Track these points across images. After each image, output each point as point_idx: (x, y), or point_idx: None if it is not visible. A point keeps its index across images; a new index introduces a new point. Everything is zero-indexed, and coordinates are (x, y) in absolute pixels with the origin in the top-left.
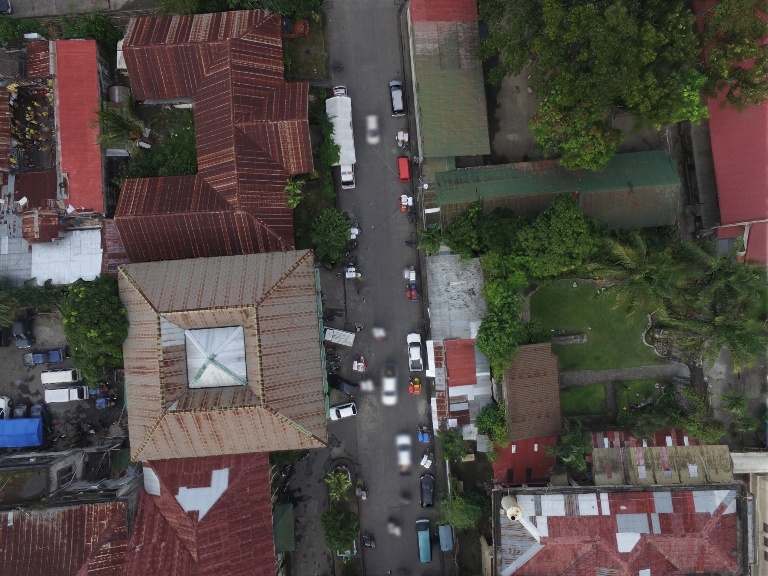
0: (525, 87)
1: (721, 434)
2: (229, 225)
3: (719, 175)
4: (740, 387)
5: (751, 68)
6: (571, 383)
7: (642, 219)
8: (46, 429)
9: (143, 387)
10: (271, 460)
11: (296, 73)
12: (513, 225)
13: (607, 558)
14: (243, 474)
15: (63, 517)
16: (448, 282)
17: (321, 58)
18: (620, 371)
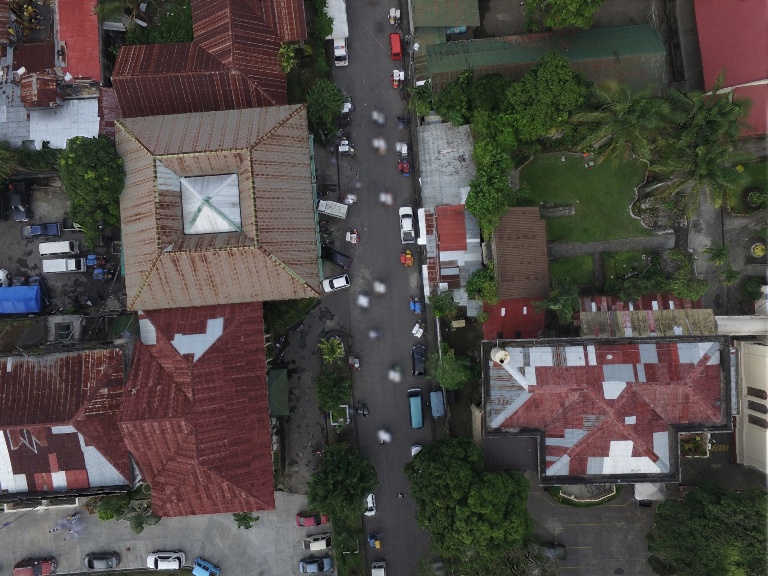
0: None
1: (705, 288)
2: (224, 87)
3: (703, 44)
4: None
5: None
6: (560, 255)
7: None
8: (44, 300)
9: (139, 233)
10: (266, 330)
11: None
12: (501, 81)
13: (594, 405)
14: (238, 323)
15: (61, 363)
16: (439, 150)
17: None
18: (608, 243)
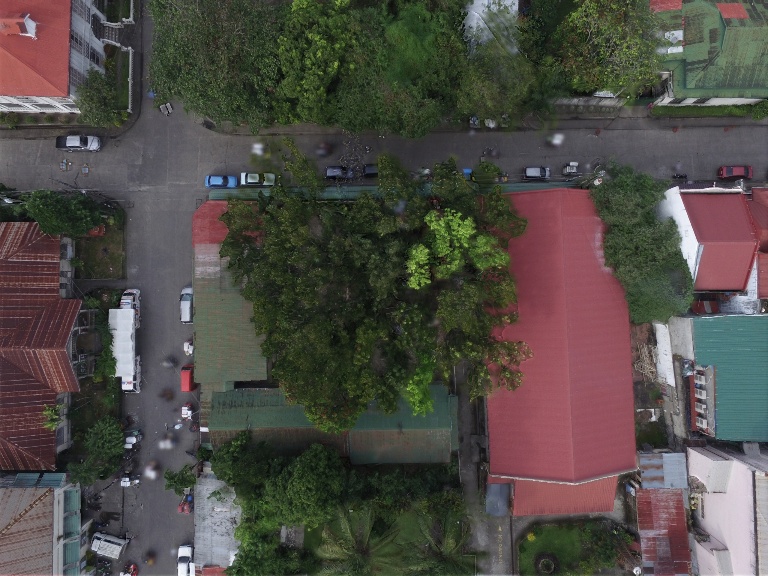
0: None
1: None
2: None
3: (491, 423)
4: None
5: (477, 366)
6: None
7: (416, 456)
8: None
9: None
10: None
11: (91, 271)
12: (257, 477)
13: None
14: None
15: None
16: (213, 507)
17: (118, 257)
18: None
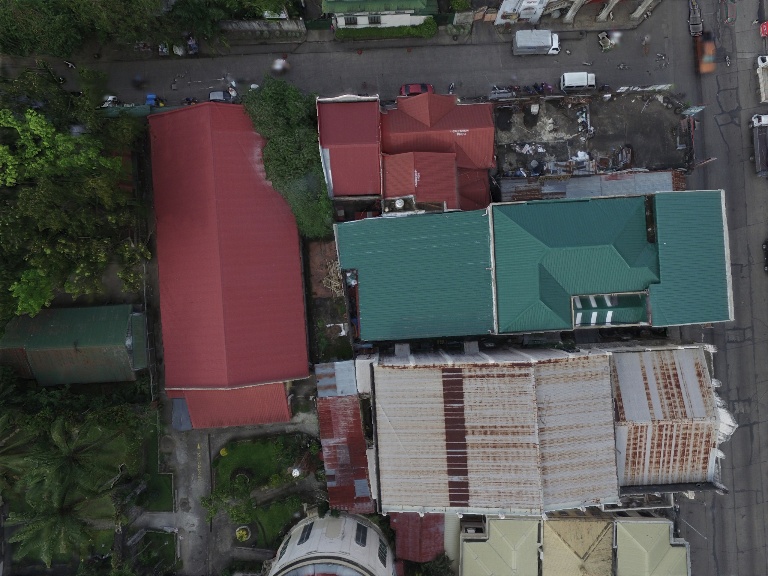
0: None
1: None
2: None
3: (164, 338)
4: (212, 540)
5: None
6: None
7: (100, 375)
8: None
9: None
10: None
11: None
12: None
13: None
14: None
15: None
16: None
17: None
18: None
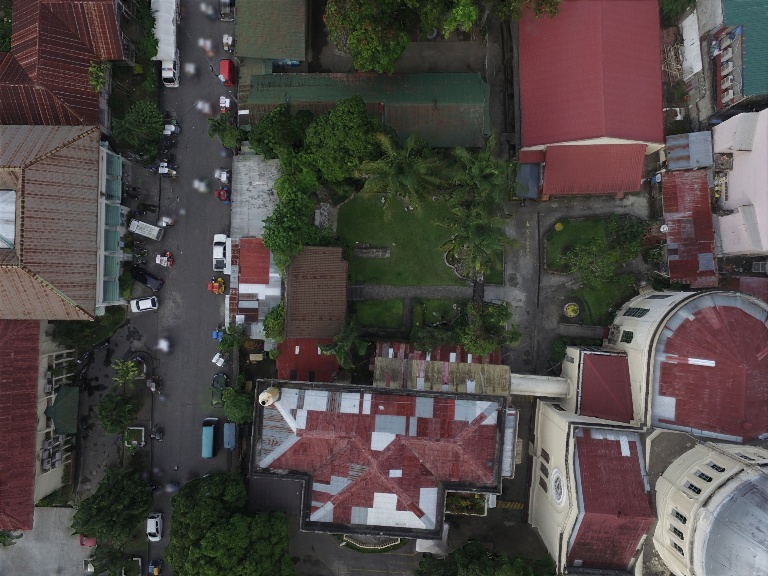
0: None
1: (490, 347)
2: (30, 100)
3: (523, 99)
4: (538, 316)
5: None
6: (371, 296)
7: (448, 138)
8: None
9: None
10: (67, 345)
11: None
12: (299, 120)
13: (359, 455)
14: (8, 339)
15: None
16: (250, 182)
17: None
18: (420, 289)
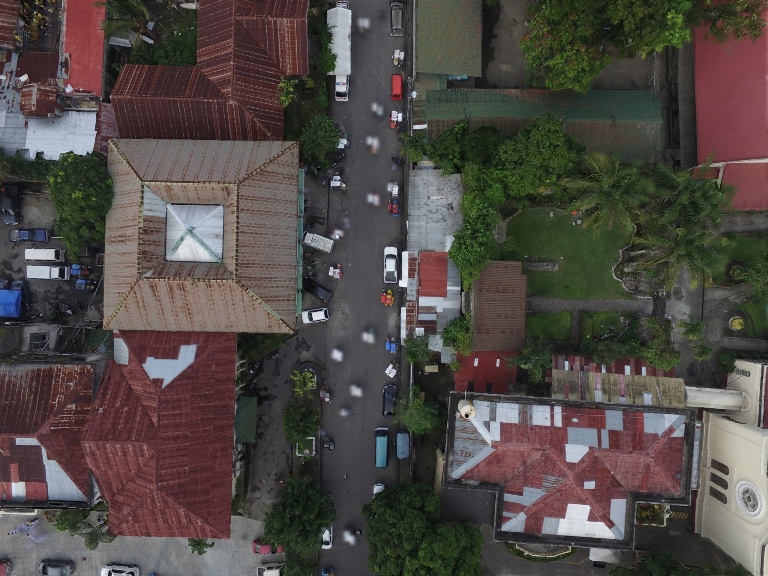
0: (522, 20)
1: (676, 361)
2: (221, 115)
3: (699, 116)
4: None
5: None
6: (539, 309)
7: (622, 154)
8: (25, 305)
9: (121, 255)
10: (241, 355)
11: None
12: (494, 137)
13: (554, 467)
14: (210, 351)
15: (32, 375)
16: (428, 196)
17: None
18: (587, 302)
